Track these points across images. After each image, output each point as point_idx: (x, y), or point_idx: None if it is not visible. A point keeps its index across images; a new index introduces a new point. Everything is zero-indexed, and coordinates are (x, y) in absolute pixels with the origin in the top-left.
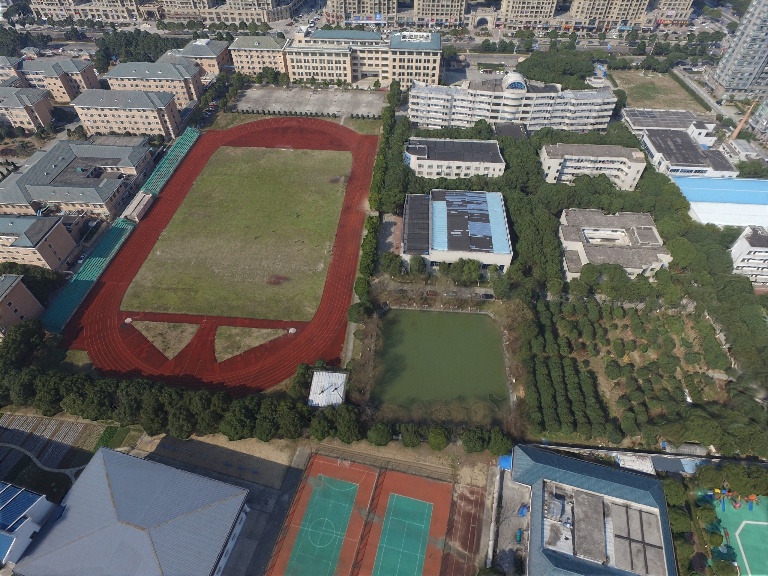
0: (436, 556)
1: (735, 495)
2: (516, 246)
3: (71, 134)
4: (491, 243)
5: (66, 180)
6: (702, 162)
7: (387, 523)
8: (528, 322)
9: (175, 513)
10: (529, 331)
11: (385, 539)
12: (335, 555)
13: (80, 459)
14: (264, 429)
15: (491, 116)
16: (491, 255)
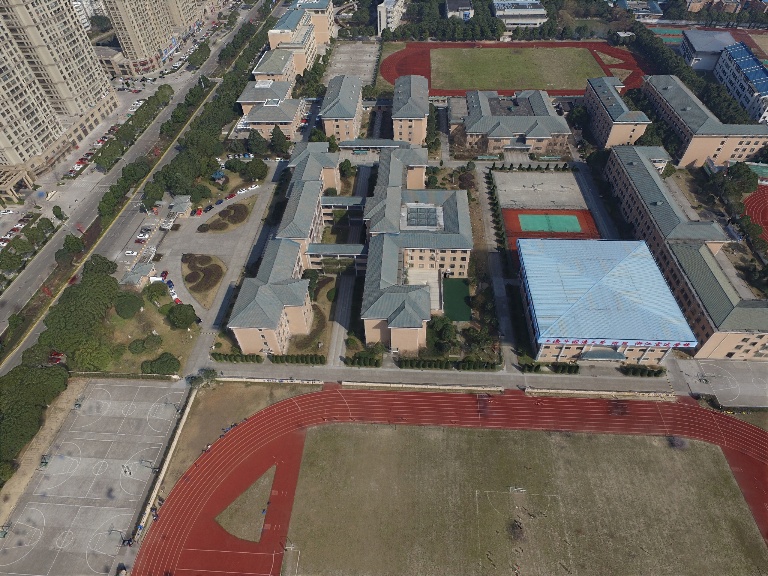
0: None
1: None
2: None
3: None
4: None
5: (526, 112)
6: None
7: None
8: None
9: (703, 34)
10: None
11: None
12: None
13: None
14: None
15: (402, 5)
16: None
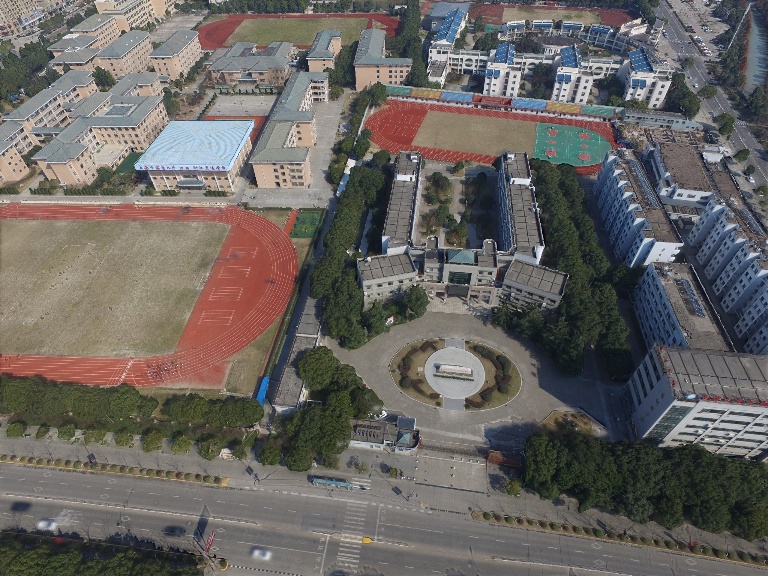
0: None
1: None
2: None
3: (180, 84)
4: None
5: None
6: None
7: None
8: None
9: None
10: None
11: None
12: None
13: (429, 37)
14: None
15: None
16: None
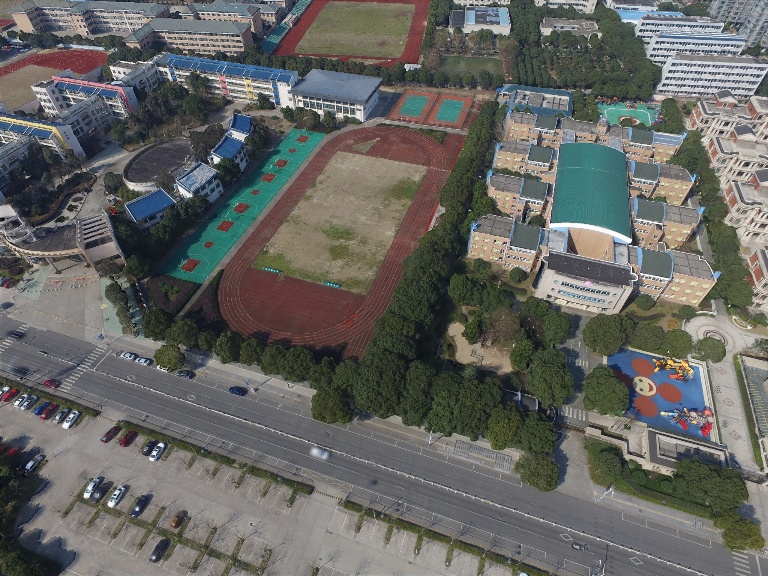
0: (465, 112)
1: (608, 100)
2: (513, 26)
3: None
4: (499, 23)
5: None
6: (636, 4)
7: (443, 105)
8: (516, 44)
9: None
10: (516, 47)
11: (442, 108)
12: (420, 110)
13: None
14: (384, 74)
15: None
16: (499, 27)
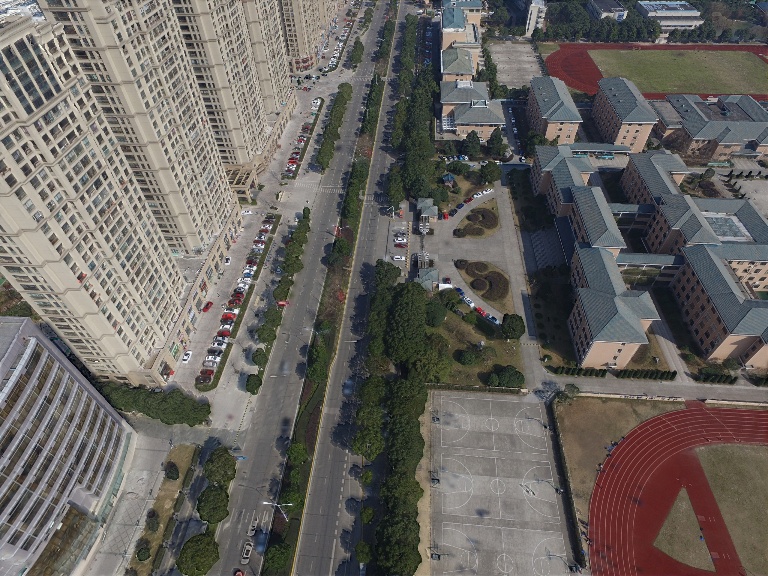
0: None
1: None
2: None
3: None
4: (681, 4)
5: (743, 117)
6: None
7: None
8: (724, 2)
9: None
10: None
11: None
12: None
13: None
14: None
15: None
16: None
